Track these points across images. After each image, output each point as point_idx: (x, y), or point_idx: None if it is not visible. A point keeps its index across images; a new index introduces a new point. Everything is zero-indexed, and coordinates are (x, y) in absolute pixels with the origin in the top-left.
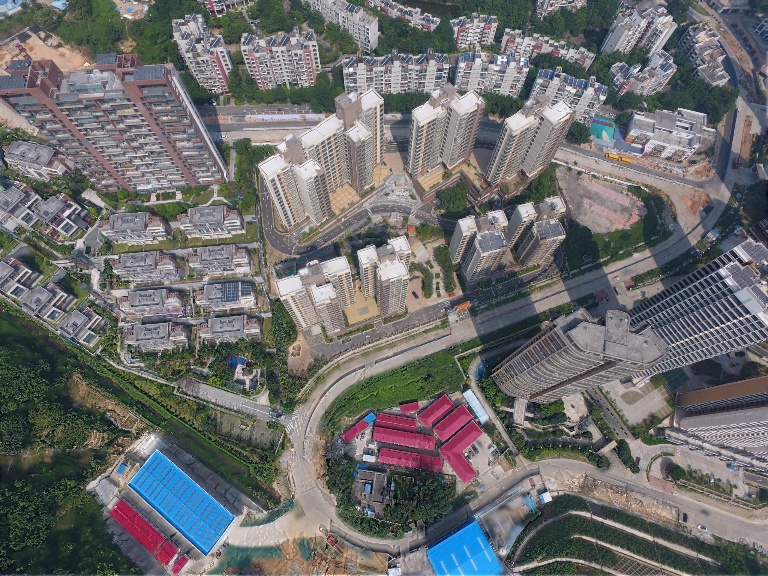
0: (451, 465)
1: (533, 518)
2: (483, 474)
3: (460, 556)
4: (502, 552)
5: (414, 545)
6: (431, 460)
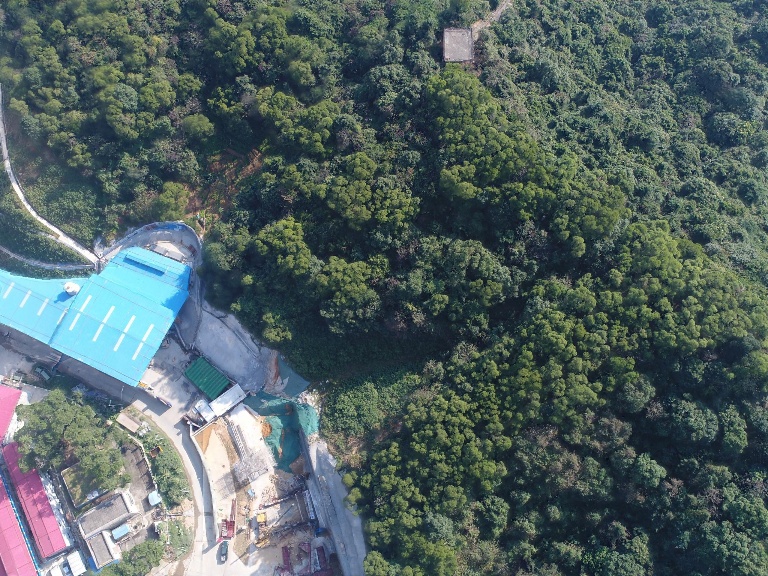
0: (4, 430)
1: (5, 273)
2: (1, 374)
3: (110, 339)
4: (70, 288)
5: (159, 407)
6: (13, 465)
